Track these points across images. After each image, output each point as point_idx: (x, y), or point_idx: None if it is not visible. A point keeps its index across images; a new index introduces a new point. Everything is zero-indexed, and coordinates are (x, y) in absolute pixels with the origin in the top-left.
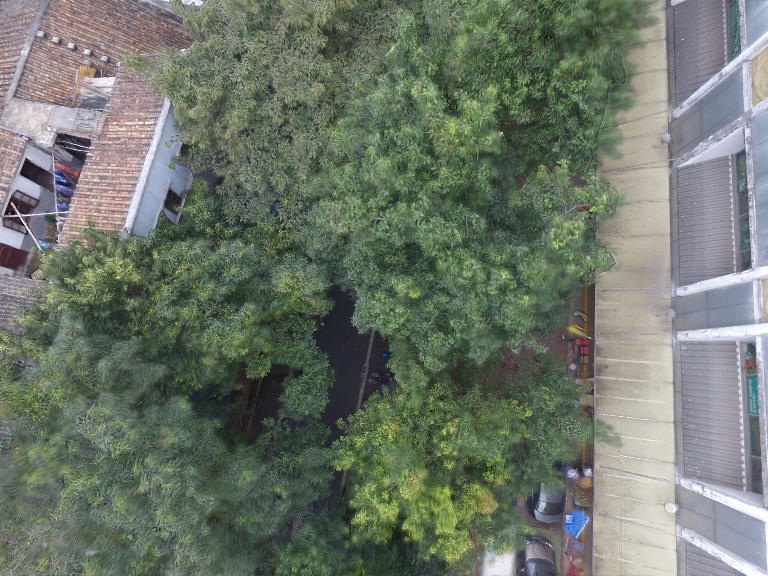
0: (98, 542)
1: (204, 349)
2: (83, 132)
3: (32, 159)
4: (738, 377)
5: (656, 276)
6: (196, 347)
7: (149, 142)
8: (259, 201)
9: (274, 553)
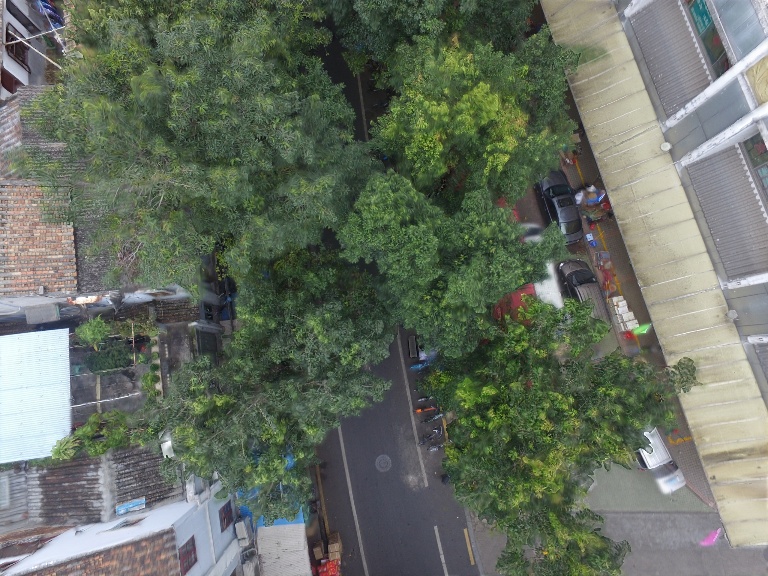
0: (213, 168)
1: None
2: None
3: None
4: (682, 14)
5: None
6: None
7: None
8: None
9: (353, 275)
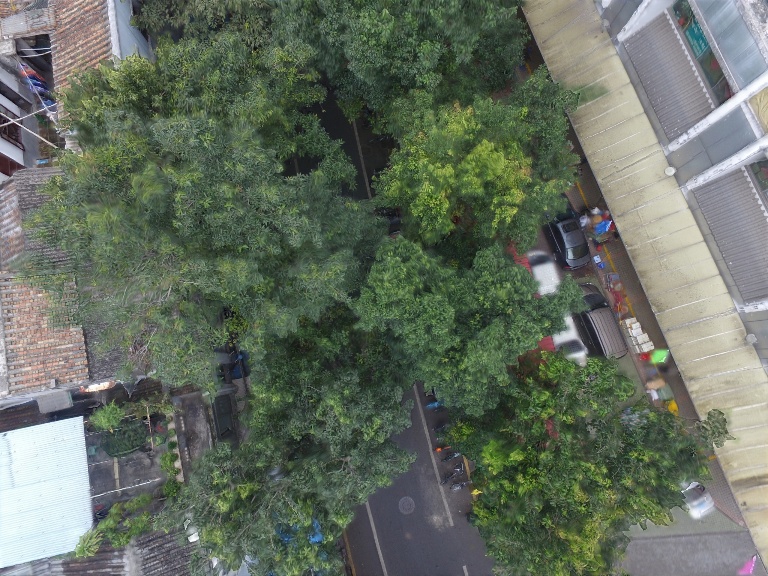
0: (220, 258)
1: (235, 126)
2: (38, 29)
3: (0, 77)
4: (677, 37)
5: (581, 7)
6: (226, 136)
7: (105, 4)
8: (223, 34)
9: None
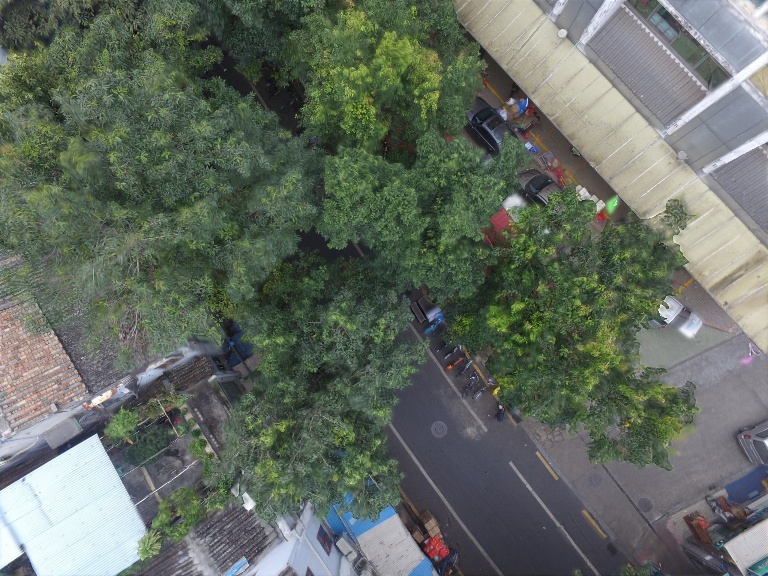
0: (176, 211)
1: None
2: None
3: None
4: None
5: None
6: None
7: None
8: None
9: (341, 266)
